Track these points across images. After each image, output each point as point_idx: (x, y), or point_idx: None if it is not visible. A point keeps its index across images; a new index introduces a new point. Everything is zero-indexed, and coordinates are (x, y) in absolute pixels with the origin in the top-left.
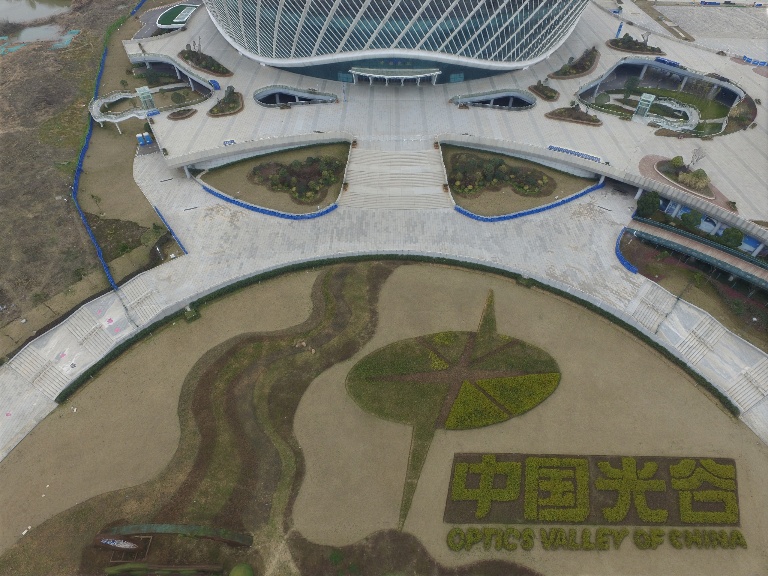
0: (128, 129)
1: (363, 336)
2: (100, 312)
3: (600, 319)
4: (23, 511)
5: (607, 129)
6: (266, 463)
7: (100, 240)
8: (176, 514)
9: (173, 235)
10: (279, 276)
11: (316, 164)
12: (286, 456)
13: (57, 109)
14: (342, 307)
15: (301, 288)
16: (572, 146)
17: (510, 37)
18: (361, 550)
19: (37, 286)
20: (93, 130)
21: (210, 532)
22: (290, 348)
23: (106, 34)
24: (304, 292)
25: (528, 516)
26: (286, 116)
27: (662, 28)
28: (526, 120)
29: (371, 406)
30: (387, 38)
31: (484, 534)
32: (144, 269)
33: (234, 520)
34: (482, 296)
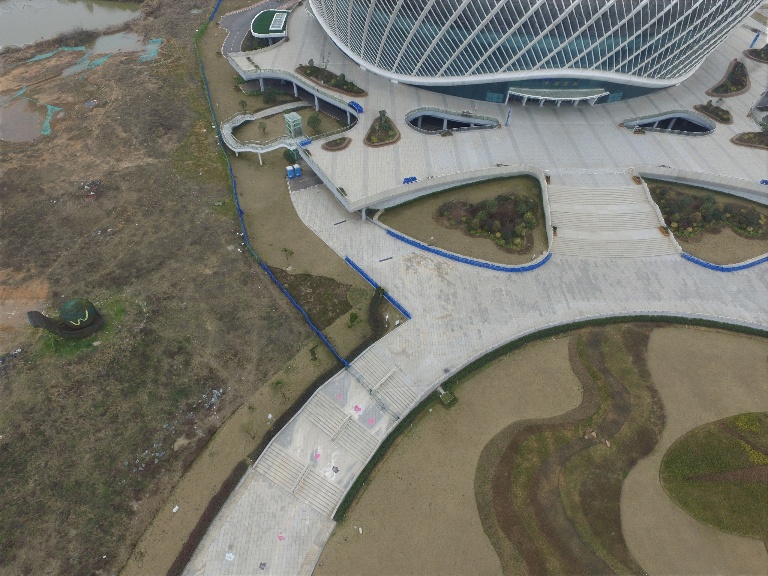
0: (267, 159)
1: (655, 422)
2: (341, 397)
3: None
4: None
5: None
6: None
7: (300, 301)
8: None
9: (383, 294)
10: (525, 345)
11: (507, 203)
12: None
13: (180, 135)
14: (614, 384)
15: (557, 360)
16: None
17: (686, 54)
18: None
19: (249, 363)
20: (229, 160)
21: None
22: (579, 440)
23: (195, 44)
24: (563, 365)
25: None
26: (453, 145)
27: None
28: (714, 147)
29: (705, 516)
30: (565, 57)
31: None
32: (372, 340)
33: None
34: (763, 366)
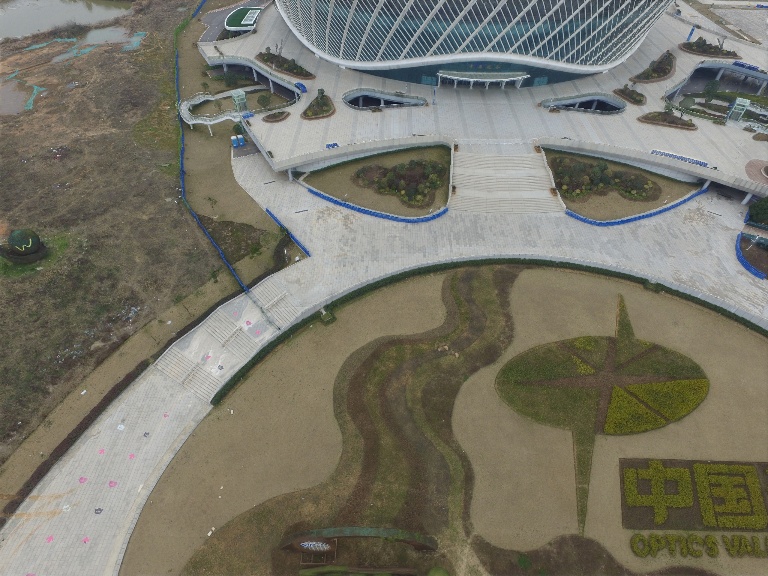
0: (218, 131)
1: (503, 340)
2: (236, 314)
3: (735, 325)
4: (203, 512)
5: (704, 133)
6: (434, 467)
7: (219, 242)
8: (355, 517)
9: (291, 238)
10: (405, 279)
11: (418, 167)
12: (452, 460)
13: (144, 111)
14: (475, 311)
15: (430, 292)
16: (673, 150)
17: (600, 41)
18: (547, 555)
19: (166, 288)
20: (184, 132)
21: (408, 536)
22: (433, 352)
23: (174, 36)
24: (434, 296)
25: (708, 523)
26: (380, 119)
27: (725, 31)
28: (620, 124)
29: (526, 411)
30: (482, 42)
31: (667, 540)
32: (272, 271)
33: (414, 524)
34: (612, 301)
